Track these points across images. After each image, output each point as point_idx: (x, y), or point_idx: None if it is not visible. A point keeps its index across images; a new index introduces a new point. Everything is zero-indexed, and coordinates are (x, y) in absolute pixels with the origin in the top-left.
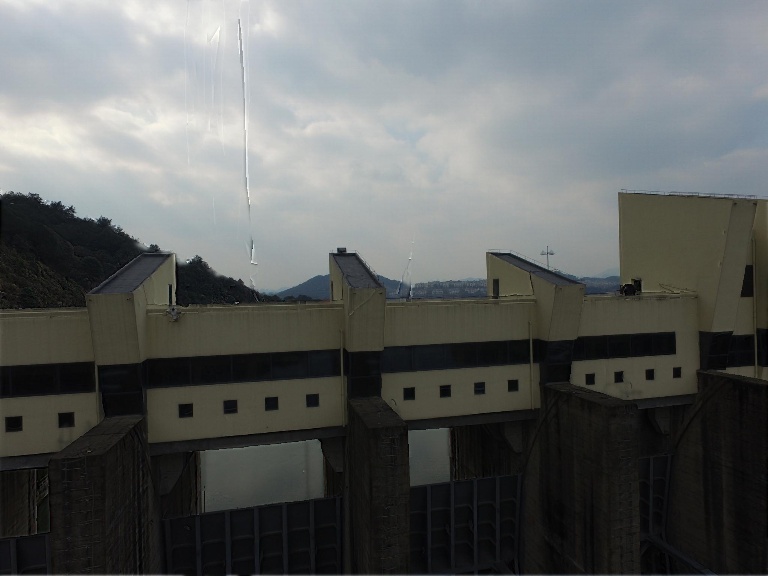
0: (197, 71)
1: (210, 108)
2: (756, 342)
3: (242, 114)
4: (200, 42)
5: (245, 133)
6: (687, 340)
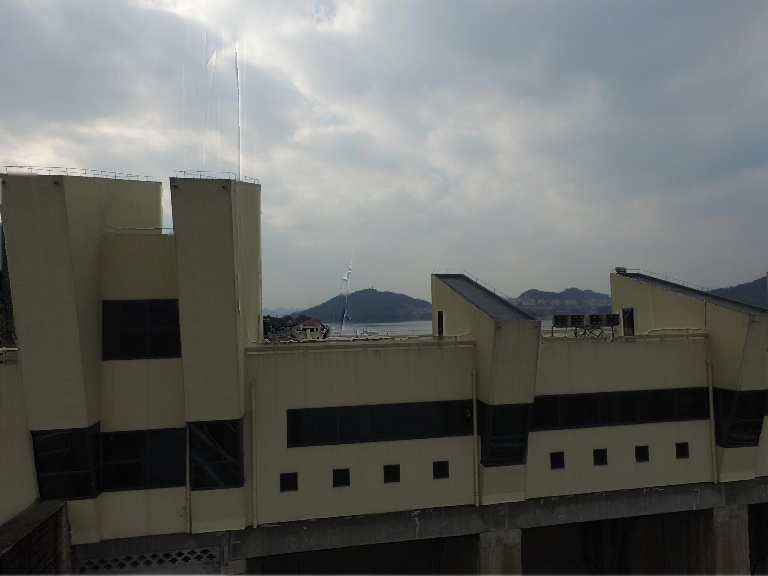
0: (196, 95)
1: (206, 130)
2: (188, 442)
3: (236, 135)
4: (200, 67)
5: (239, 153)
6: (15, 442)
